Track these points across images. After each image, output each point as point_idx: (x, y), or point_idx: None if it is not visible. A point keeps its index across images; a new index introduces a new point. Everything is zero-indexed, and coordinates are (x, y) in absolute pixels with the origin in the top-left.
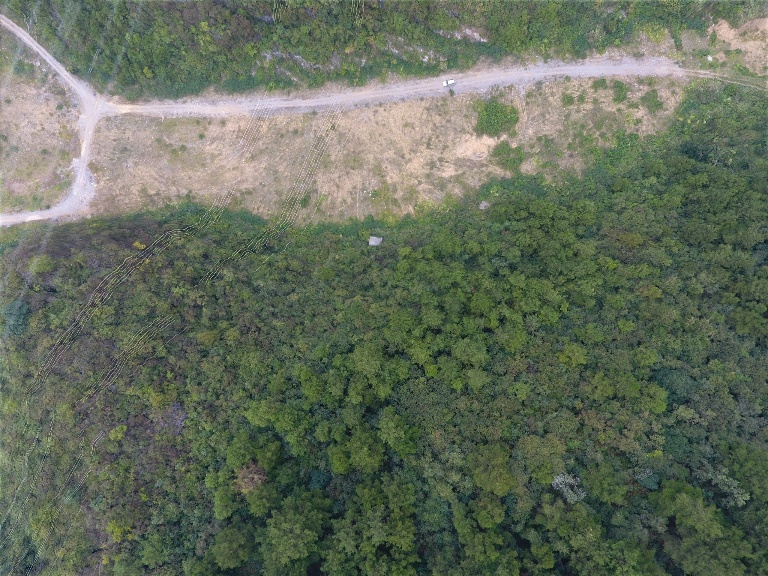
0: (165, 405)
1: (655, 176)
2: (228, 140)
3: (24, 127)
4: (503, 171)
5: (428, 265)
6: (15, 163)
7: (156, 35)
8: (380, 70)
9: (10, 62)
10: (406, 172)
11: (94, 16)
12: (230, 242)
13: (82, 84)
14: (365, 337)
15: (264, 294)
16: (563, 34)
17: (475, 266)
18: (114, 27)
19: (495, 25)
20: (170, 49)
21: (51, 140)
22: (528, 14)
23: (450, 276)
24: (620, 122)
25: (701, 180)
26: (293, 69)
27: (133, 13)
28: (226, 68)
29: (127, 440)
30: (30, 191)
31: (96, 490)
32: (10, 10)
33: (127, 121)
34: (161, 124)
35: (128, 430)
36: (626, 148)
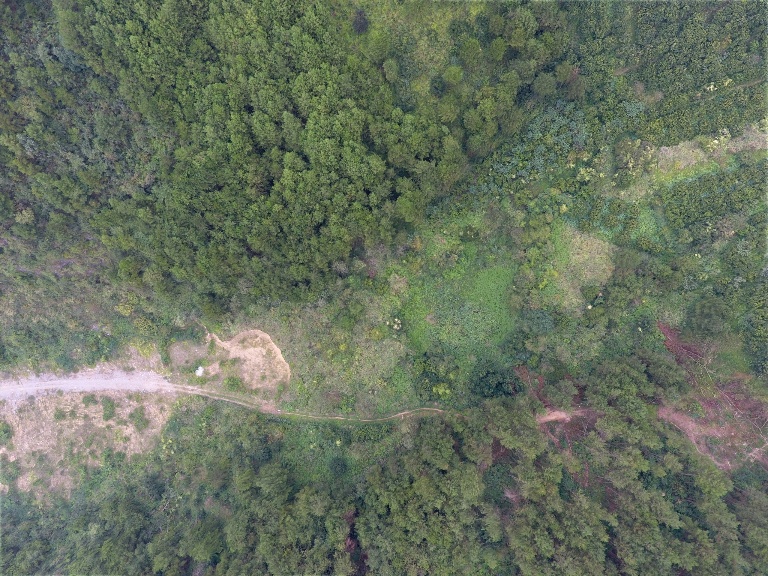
0: None
1: (99, 524)
2: None
3: None
4: None
5: None
6: None
7: None
8: None
9: None
10: None
11: None
12: None
13: None
14: None
15: None
16: (48, 351)
17: None
18: None
19: None
20: None
21: None
22: None
23: None
24: (109, 440)
25: (102, 555)
26: None
27: None
28: None
29: None
30: None
31: None
32: None
33: None
34: None
35: None
36: (106, 472)
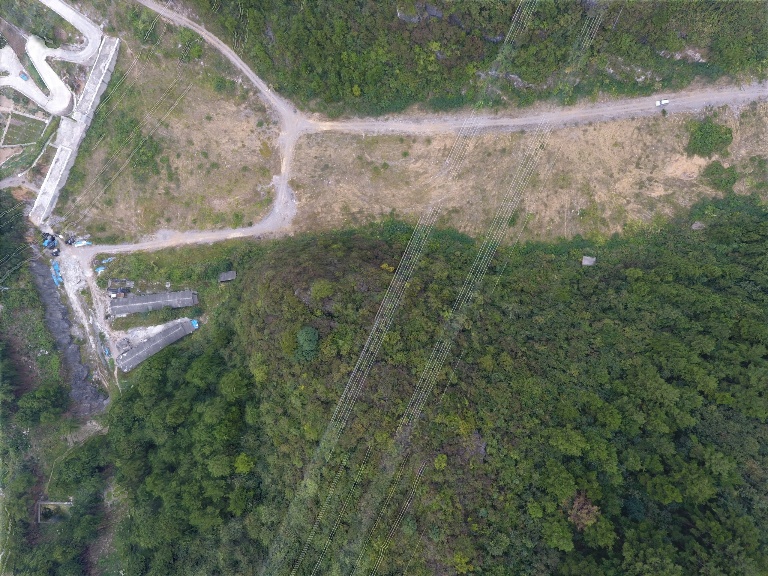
0: (468, 433)
1: None
2: (434, 158)
3: (225, 144)
4: (714, 191)
5: (673, 288)
6: (215, 180)
7: (373, 54)
8: (592, 89)
9: (212, 79)
10: (615, 191)
11: (314, 35)
12: (456, 262)
13: (283, 101)
14: (635, 362)
15: (512, 317)
16: None
17: (721, 290)
18: (332, 46)
19: (723, 46)
20: (383, 68)
21: (251, 157)
22: (753, 35)
23: (707, 300)
24: None
25: None
26: (505, 88)
27: (354, 32)
28: (436, 86)
29: (448, 469)
30: (231, 208)
31: (433, 521)
32: (221, 28)
33: (328, 138)
34: (362, 141)
35: (448, 459)
36: None
